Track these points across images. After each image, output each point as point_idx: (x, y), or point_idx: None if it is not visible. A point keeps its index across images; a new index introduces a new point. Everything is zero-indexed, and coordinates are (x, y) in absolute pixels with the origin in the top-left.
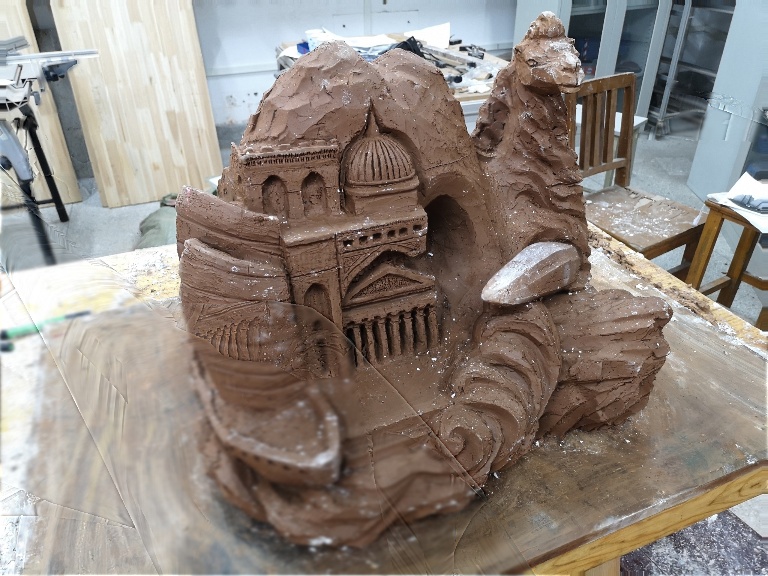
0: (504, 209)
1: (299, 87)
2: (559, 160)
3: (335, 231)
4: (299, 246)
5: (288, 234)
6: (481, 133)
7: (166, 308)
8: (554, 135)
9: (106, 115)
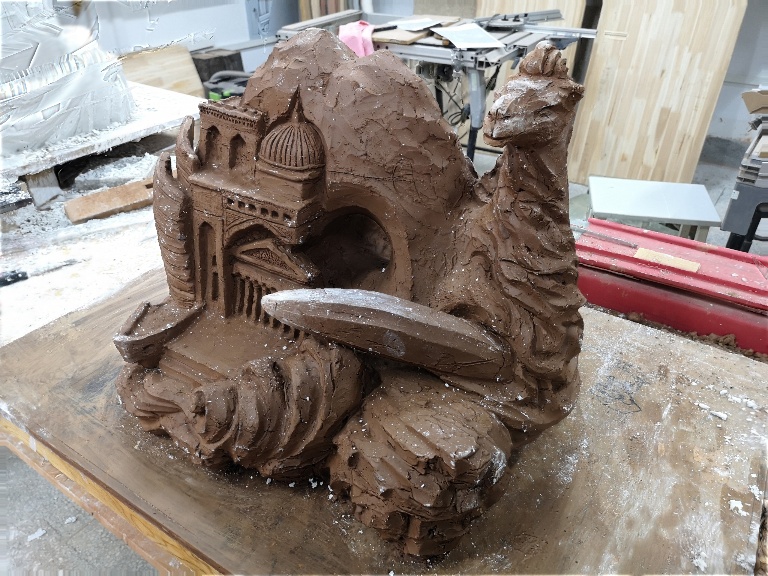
0: (456, 261)
1: (267, 62)
2: (515, 232)
3: (221, 186)
4: (198, 186)
5: (199, 174)
6: (496, 173)
7: None
8: (518, 199)
9: (605, 96)
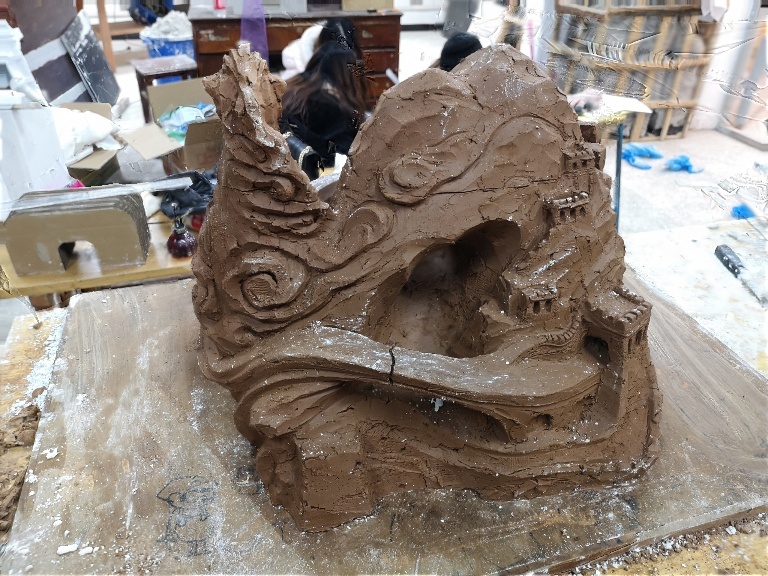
0: None
1: None
2: None
3: None
4: None
5: None
6: None
7: (504, 3)
8: None
9: None
